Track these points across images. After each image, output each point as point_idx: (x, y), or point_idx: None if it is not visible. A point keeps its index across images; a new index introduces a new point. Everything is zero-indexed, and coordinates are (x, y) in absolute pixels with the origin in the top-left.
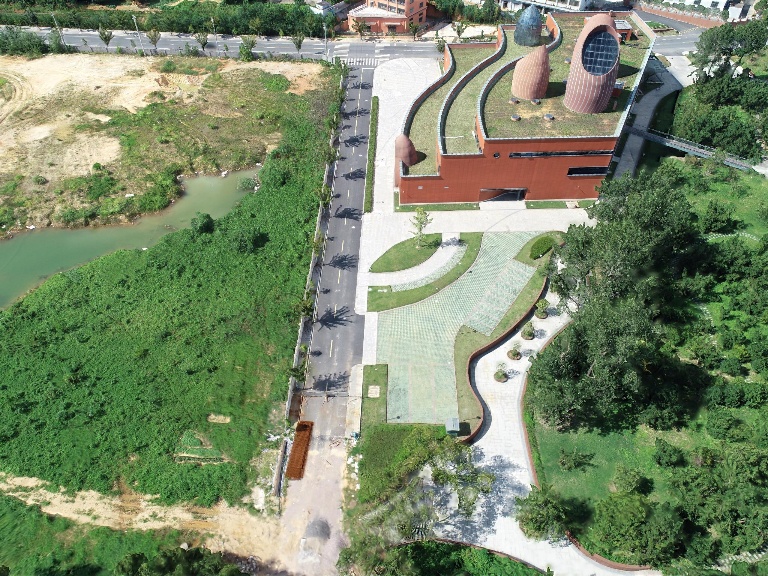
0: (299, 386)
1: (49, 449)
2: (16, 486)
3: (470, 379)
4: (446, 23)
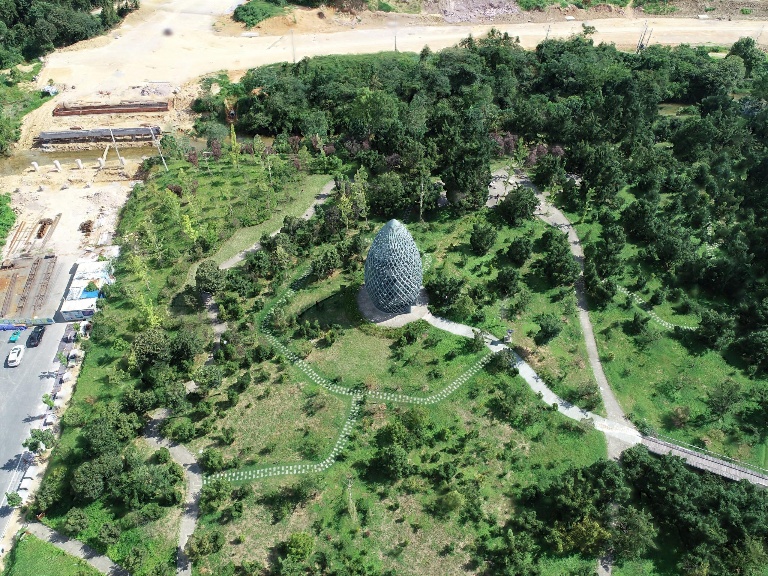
0: None
1: None
2: None
3: None
4: None
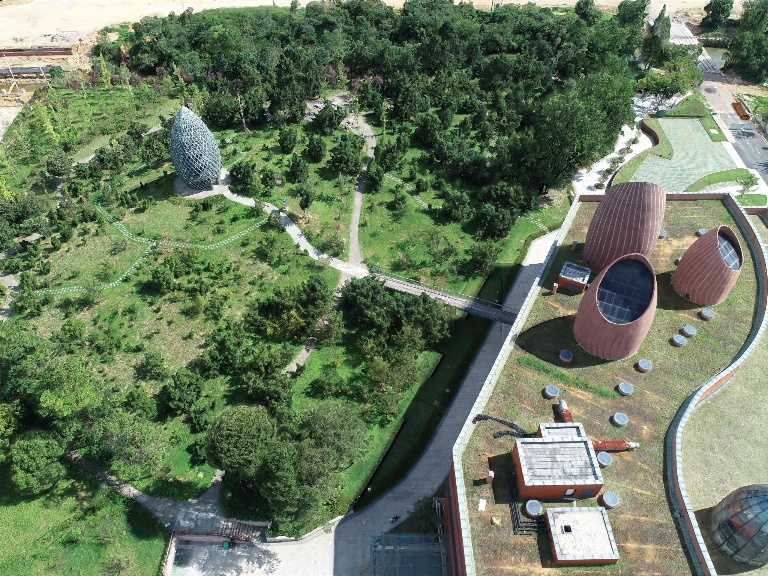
0: (763, 133)
1: None
2: None
3: (654, 141)
4: None
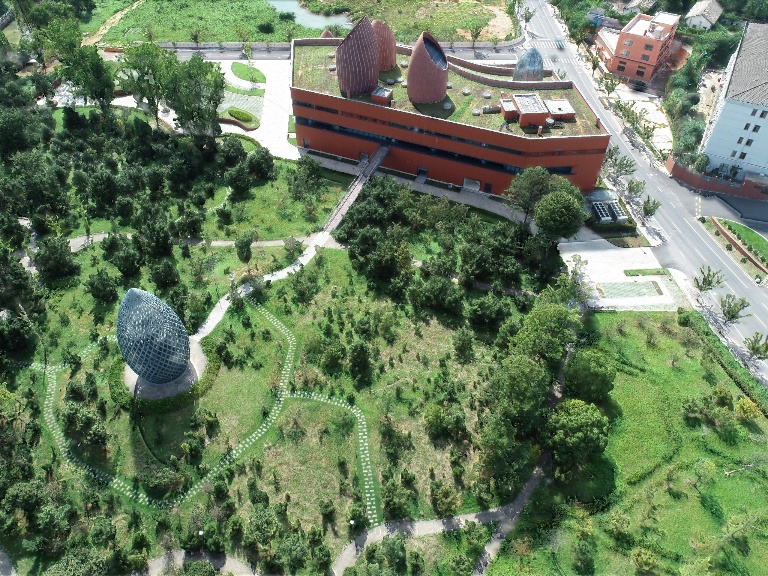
0: None
1: (147, 7)
2: (134, 6)
3: None
4: (656, 93)
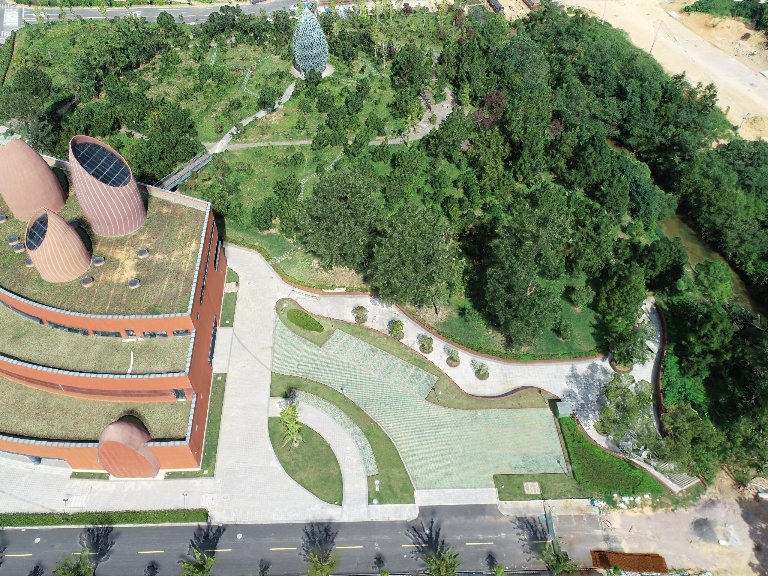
0: None
1: None
2: None
3: None
4: None
